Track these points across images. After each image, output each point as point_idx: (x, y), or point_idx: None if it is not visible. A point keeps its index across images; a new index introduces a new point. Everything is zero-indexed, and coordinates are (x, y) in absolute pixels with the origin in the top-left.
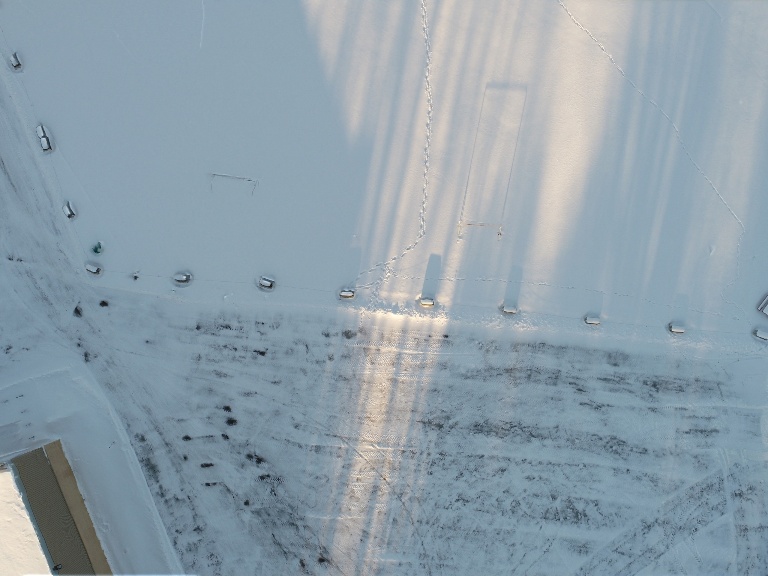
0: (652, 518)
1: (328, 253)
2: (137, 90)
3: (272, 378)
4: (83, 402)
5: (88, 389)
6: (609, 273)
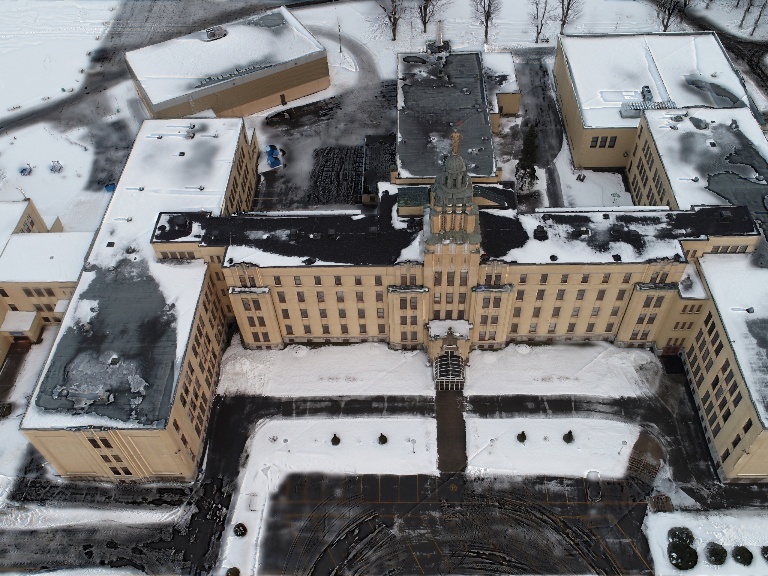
0: None
1: None
2: (5, 91)
3: None
4: None
5: None
6: None
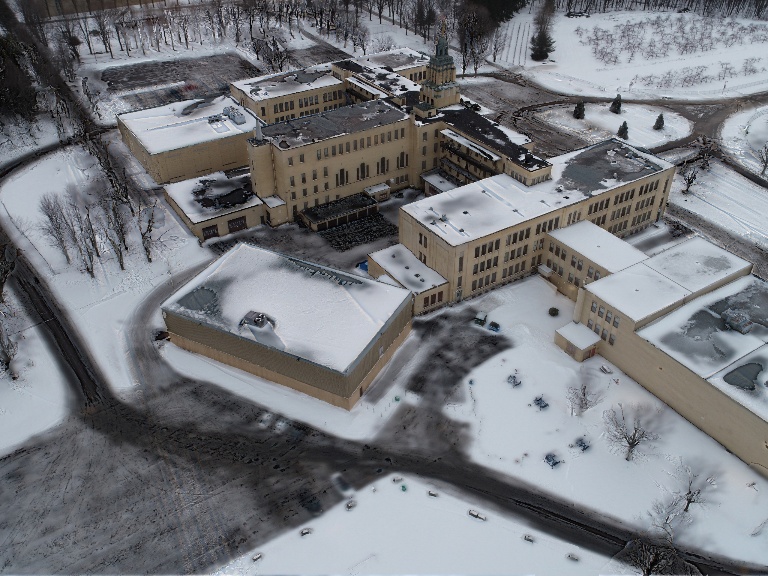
0: (6, 571)
1: (283, 569)
2: (458, 574)
3: (271, 496)
4: (353, 430)
5: (355, 436)
6: None
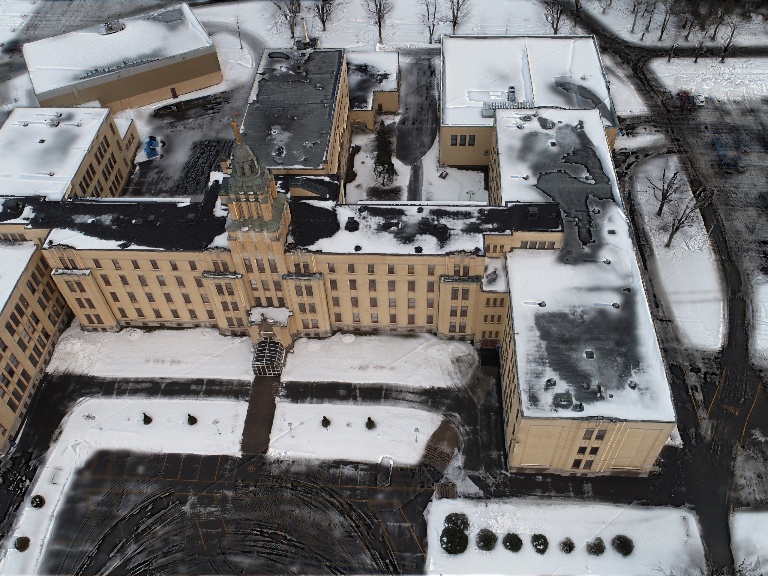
0: None
1: None
2: None
3: None
4: None
5: None
6: None
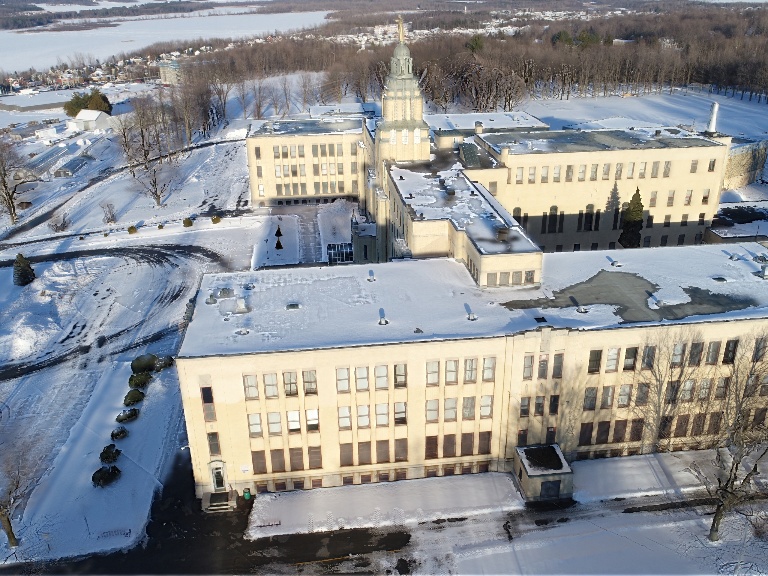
0: None
1: None
2: None
3: None
4: None
5: None
6: (736, 128)
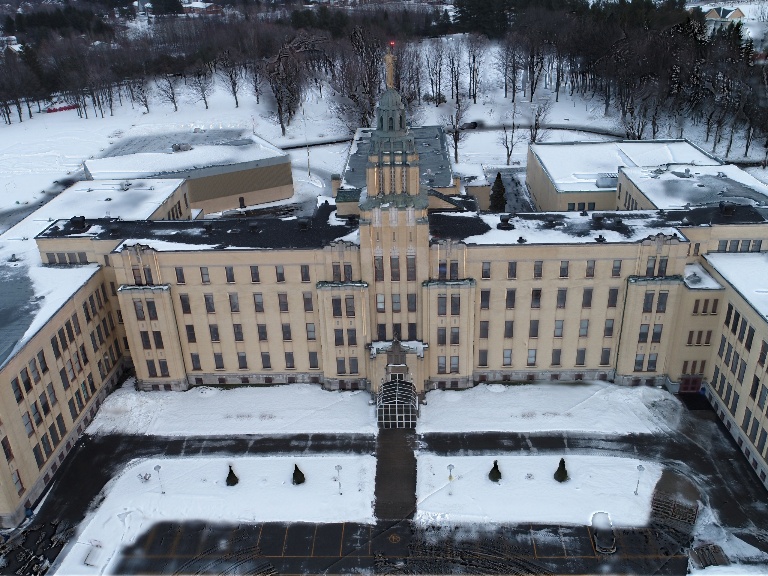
0: None
1: None
2: None
3: None
4: None
5: None
6: (88, 147)
